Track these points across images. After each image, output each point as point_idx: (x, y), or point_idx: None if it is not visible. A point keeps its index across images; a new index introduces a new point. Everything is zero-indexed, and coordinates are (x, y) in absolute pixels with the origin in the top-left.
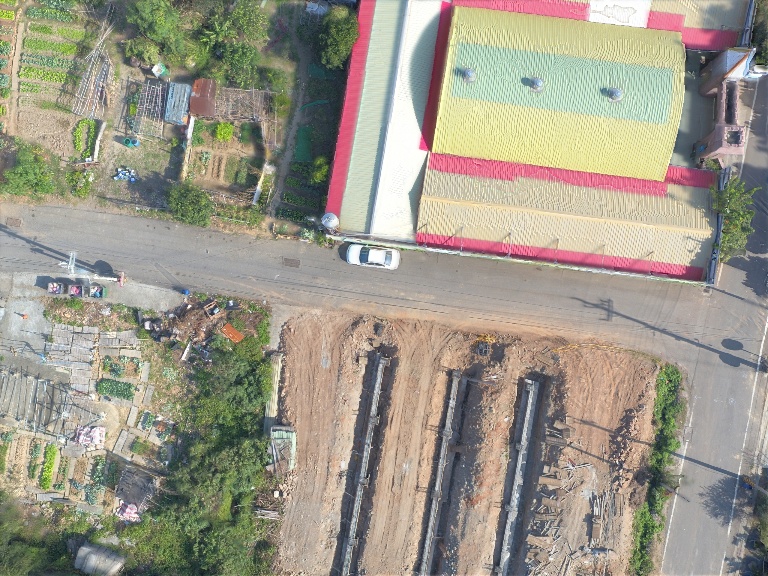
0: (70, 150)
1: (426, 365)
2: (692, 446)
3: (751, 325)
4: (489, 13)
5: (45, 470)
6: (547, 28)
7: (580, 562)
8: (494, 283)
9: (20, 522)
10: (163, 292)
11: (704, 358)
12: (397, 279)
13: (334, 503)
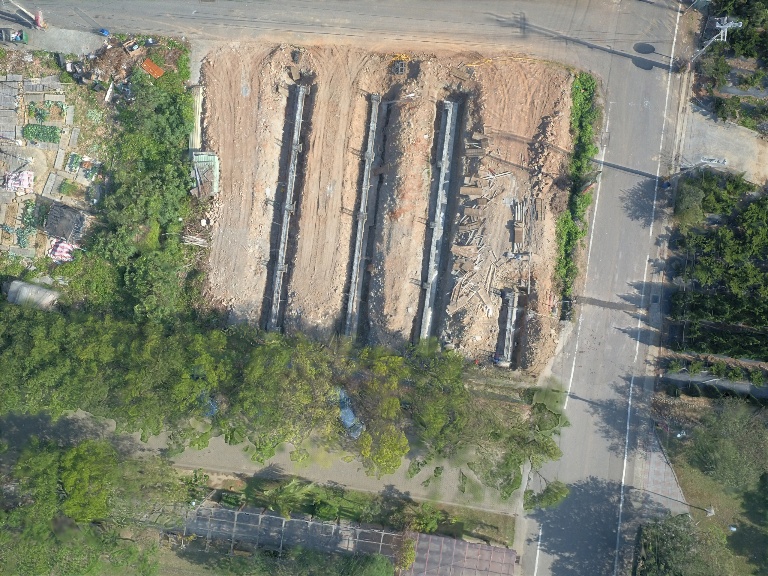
0: None
1: (345, 89)
2: (610, 151)
3: (661, 27)
4: None
5: None
6: None
7: (505, 270)
8: (407, 3)
9: None
10: (83, 36)
11: (617, 63)
12: (312, 6)
13: (261, 230)
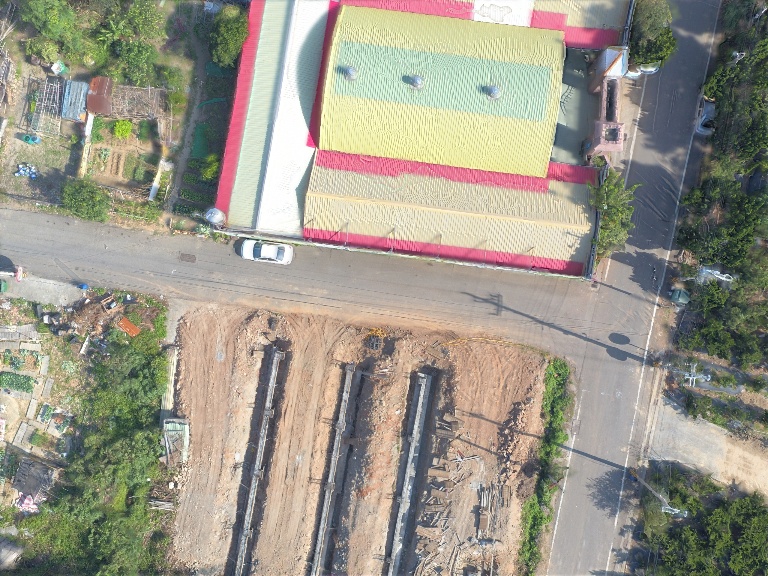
0: None
1: (319, 359)
2: (580, 439)
3: (637, 320)
4: (373, 12)
5: None
6: (428, 27)
7: (469, 553)
8: (386, 278)
9: None
10: (62, 287)
11: (591, 352)
12: (291, 274)
13: (229, 494)
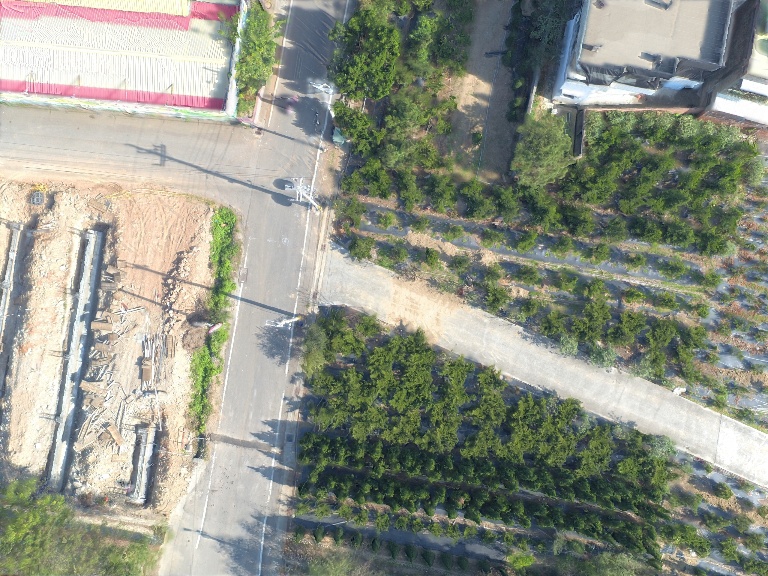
0: None
1: None
2: (247, 287)
3: (301, 164)
4: None
5: None
6: None
7: (137, 407)
8: (47, 132)
9: None
10: None
11: (256, 199)
12: None
13: None
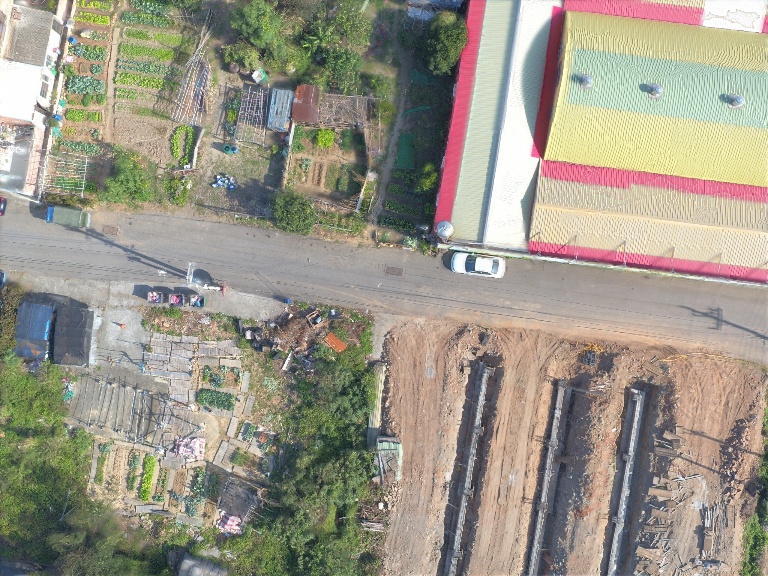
0: (167, 157)
1: (532, 375)
2: None
3: None
4: (604, 18)
5: (144, 482)
6: (664, 33)
7: (690, 574)
8: (601, 291)
9: (119, 534)
10: (263, 301)
11: None
12: (502, 288)
13: (439, 515)
